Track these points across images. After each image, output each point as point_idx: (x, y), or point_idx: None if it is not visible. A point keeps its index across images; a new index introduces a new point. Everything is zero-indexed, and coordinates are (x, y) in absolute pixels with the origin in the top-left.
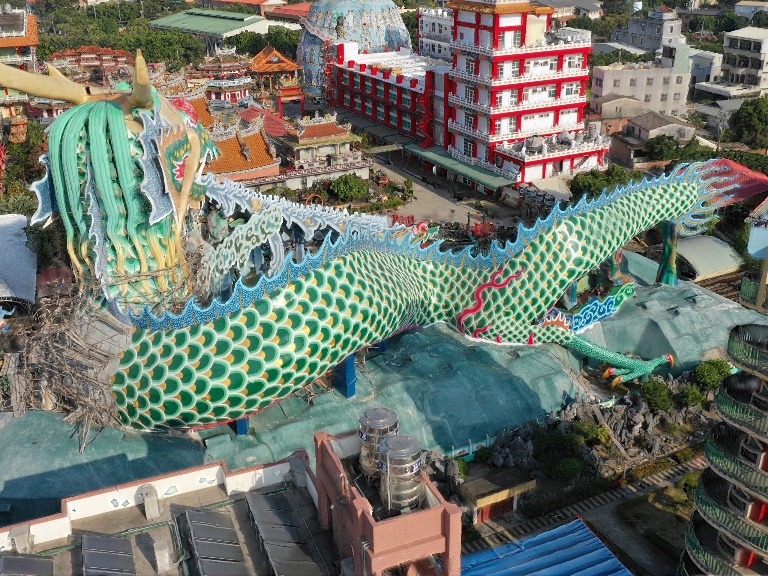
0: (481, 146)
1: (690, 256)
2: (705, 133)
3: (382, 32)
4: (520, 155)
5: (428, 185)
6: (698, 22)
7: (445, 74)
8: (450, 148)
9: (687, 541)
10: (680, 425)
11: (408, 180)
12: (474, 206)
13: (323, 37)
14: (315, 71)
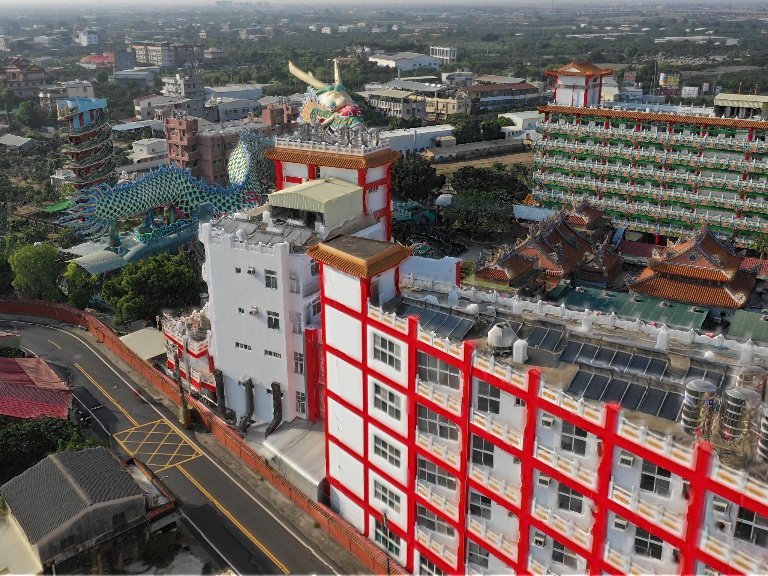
0: None
1: None
2: None
3: None
4: None
5: None
6: None
7: None
8: None
9: None
10: None
11: None
12: None
13: None
14: None
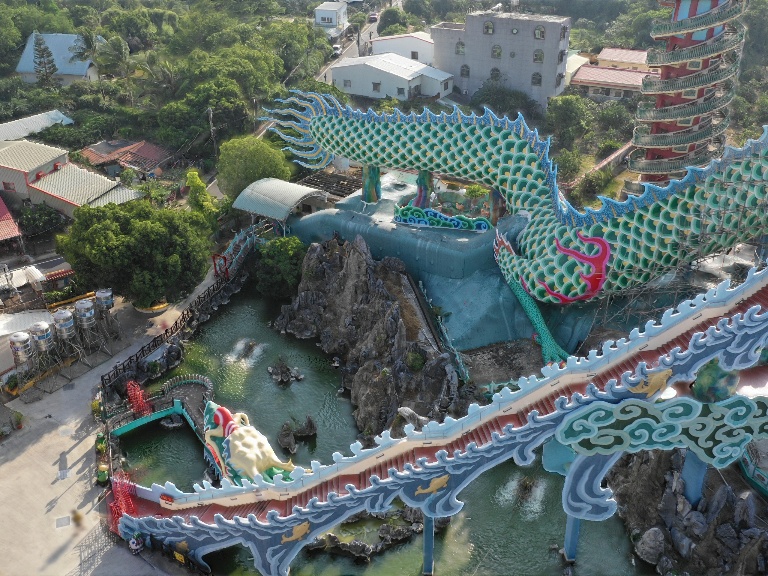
0: None
1: None
2: None
3: None
4: None
5: None
6: None
7: None
8: None
9: (704, 163)
10: None
11: None
12: None
13: None
14: None
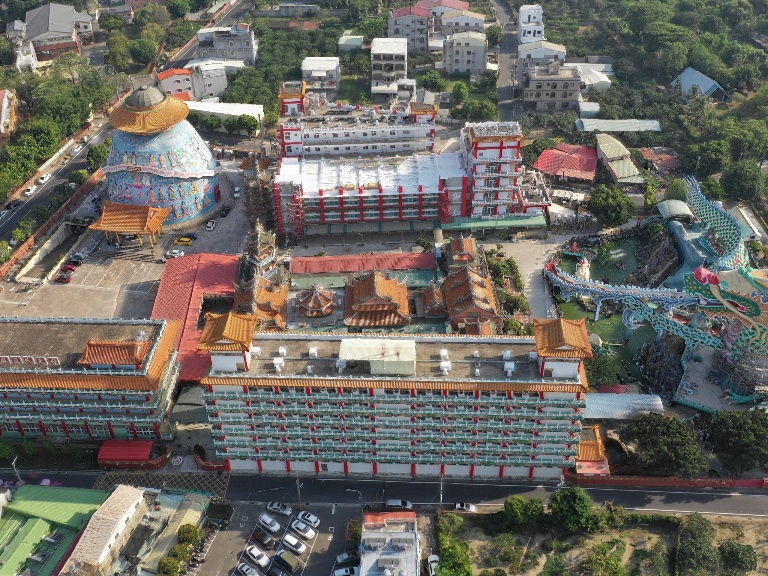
0: (503, 206)
1: (687, 212)
2: (443, 127)
3: (206, 148)
4: (547, 202)
5: (477, 242)
6: (178, 7)
7: (466, 177)
8: (474, 215)
9: None
10: (766, 267)
11: (501, 245)
12: (523, 238)
13: (183, 176)
14: (178, 205)
